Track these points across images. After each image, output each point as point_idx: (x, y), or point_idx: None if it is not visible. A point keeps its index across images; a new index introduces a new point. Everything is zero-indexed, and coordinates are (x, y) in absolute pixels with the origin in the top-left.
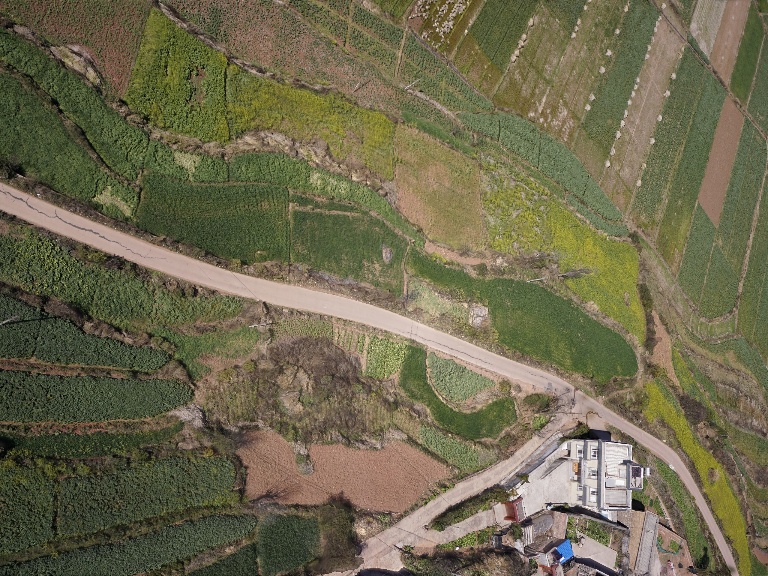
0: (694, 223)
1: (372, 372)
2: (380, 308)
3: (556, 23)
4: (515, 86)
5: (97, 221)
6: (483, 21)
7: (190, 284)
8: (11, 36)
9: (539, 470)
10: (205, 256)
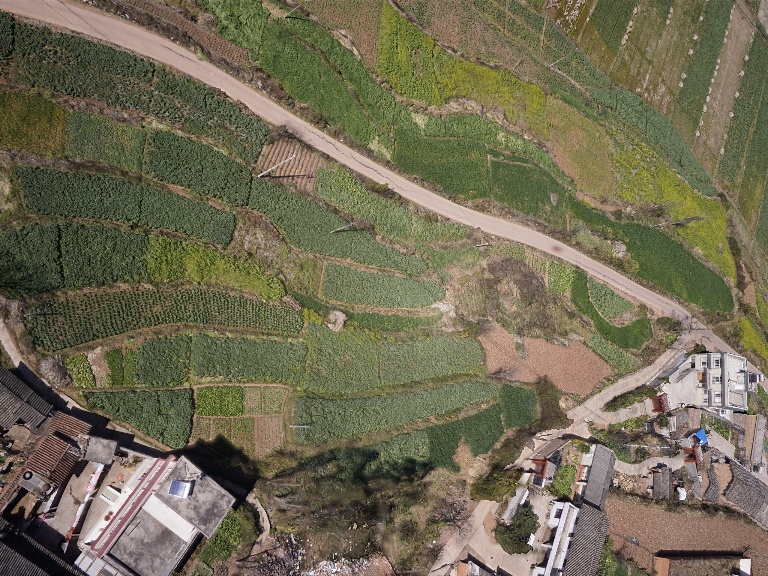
0: (766, 188)
1: (553, 289)
2: (554, 239)
3: (654, 11)
4: (625, 65)
5: (375, 161)
6: (600, 10)
7: (433, 212)
8: (311, 22)
9: (673, 376)
10: (441, 192)
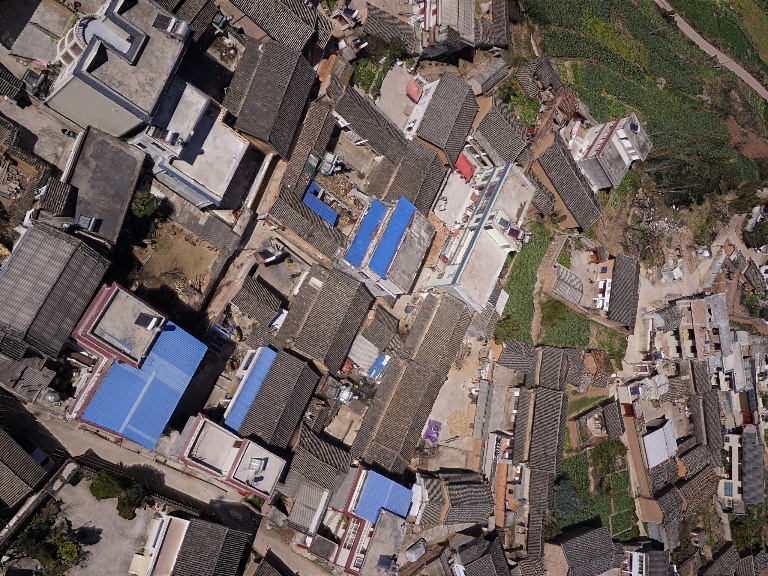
0: None
1: None
2: (753, 78)
3: None
4: None
5: None
6: None
7: (691, 40)
8: None
9: None
10: (694, 27)
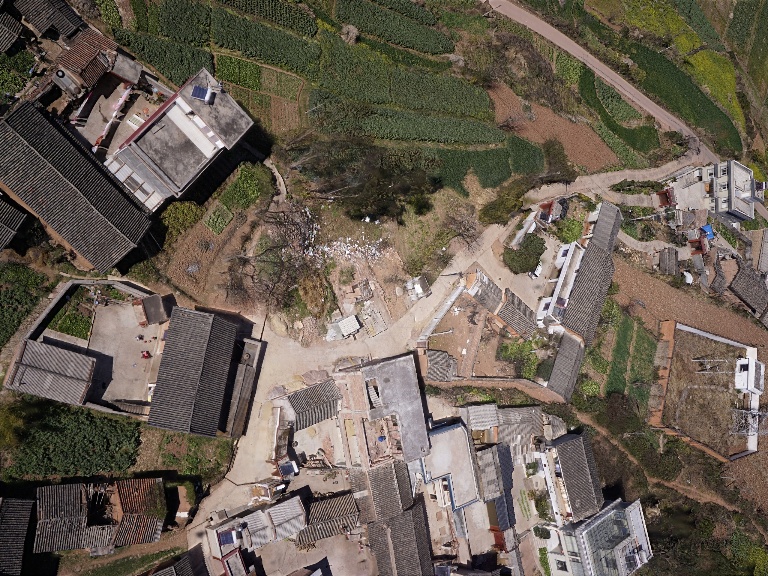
0: None
1: None
2: (562, 33)
3: None
4: None
5: None
6: None
7: None
8: None
9: (680, 182)
10: None
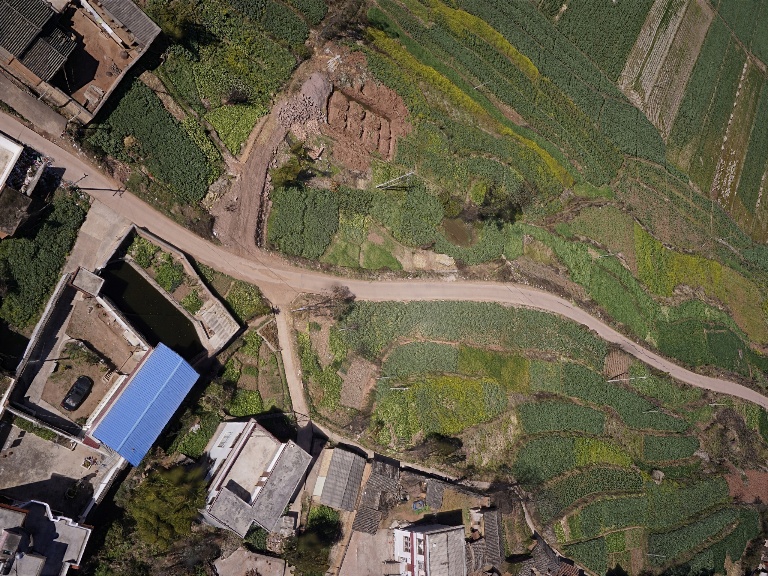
0: None
1: (749, 426)
2: (747, 388)
3: None
4: (759, 224)
5: (654, 353)
6: (742, 184)
7: (683, 382)
8: (611, 257)
9: None
10: None
